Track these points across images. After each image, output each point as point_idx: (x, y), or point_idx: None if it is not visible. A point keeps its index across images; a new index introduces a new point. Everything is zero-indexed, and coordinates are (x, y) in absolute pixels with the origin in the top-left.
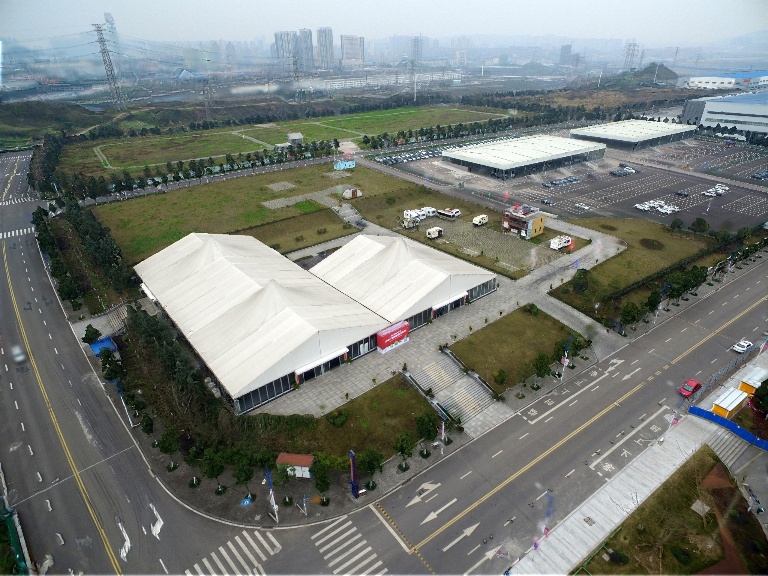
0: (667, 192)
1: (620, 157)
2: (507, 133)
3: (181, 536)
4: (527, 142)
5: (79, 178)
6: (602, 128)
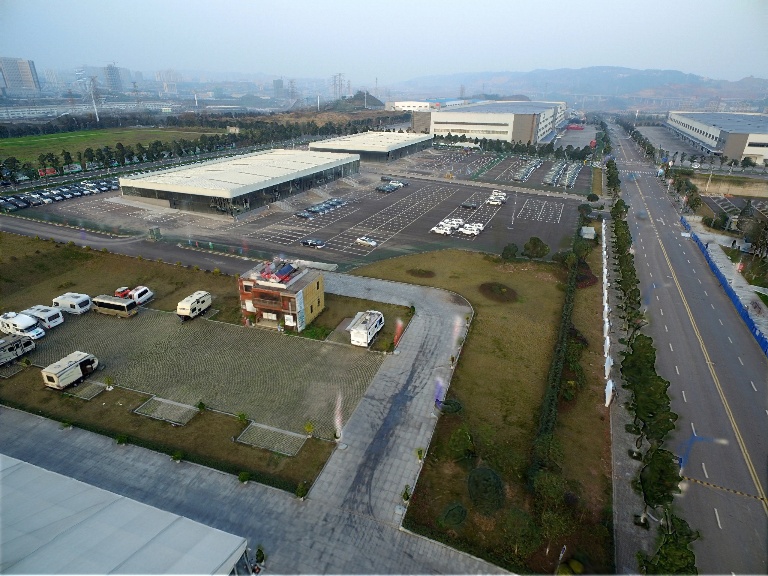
0: (452, 206)
1: (376, 170)
2: (230, 152)
3: None
4: (258, 158)
5: None
6: (344, 140)
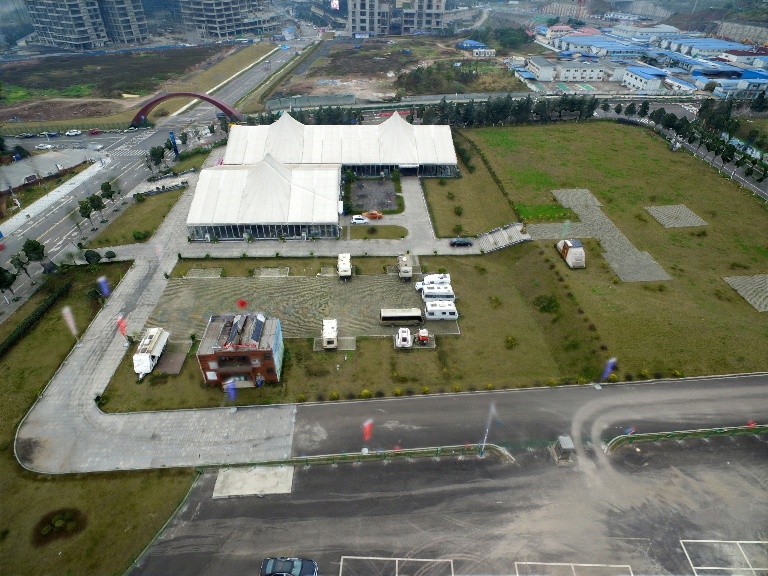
0: None
1: None
2: None
3: (224, 136)
4: None
5: (718, 109)
6: None
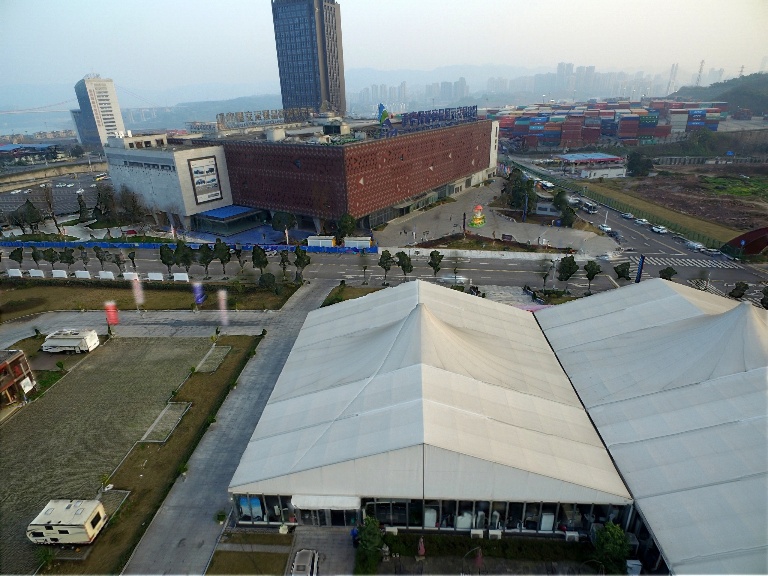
0: None
1: None
2: None
3: None
4: None
5: None
6: None
